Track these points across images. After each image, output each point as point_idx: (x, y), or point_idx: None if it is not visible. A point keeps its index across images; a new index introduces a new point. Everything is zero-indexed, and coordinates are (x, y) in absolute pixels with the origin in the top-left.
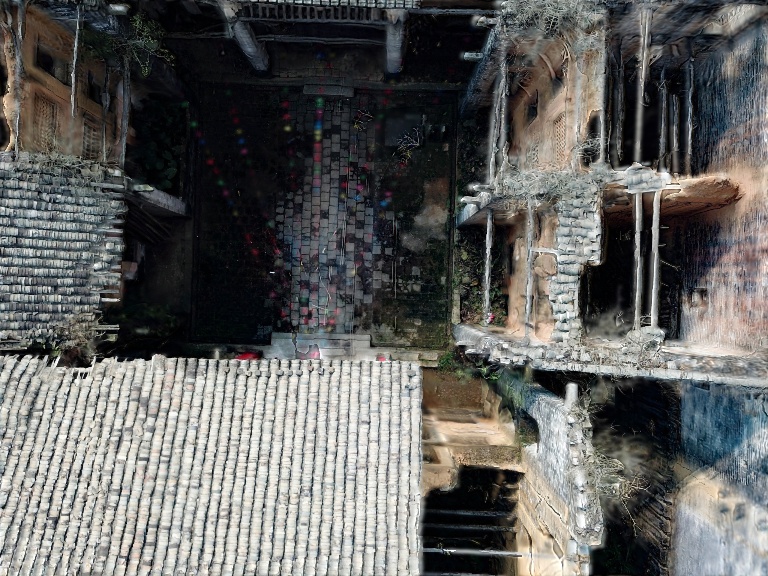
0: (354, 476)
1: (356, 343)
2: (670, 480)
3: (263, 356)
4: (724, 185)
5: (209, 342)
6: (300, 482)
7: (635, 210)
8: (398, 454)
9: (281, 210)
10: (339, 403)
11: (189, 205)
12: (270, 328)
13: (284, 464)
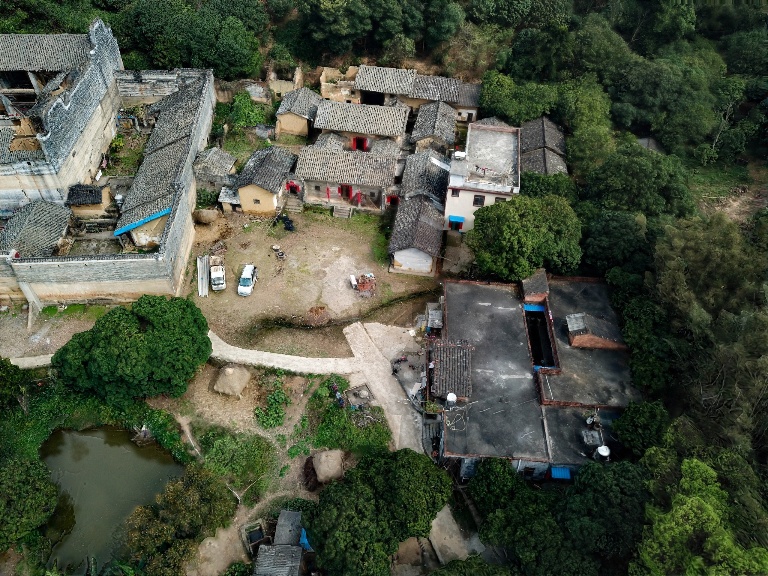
0: None
1: None
2: None
3: None
4: None
5: None
6: (3, 54)
7: None
8: None
9: None
10: None
11: None
12: None
13: (6, 56)
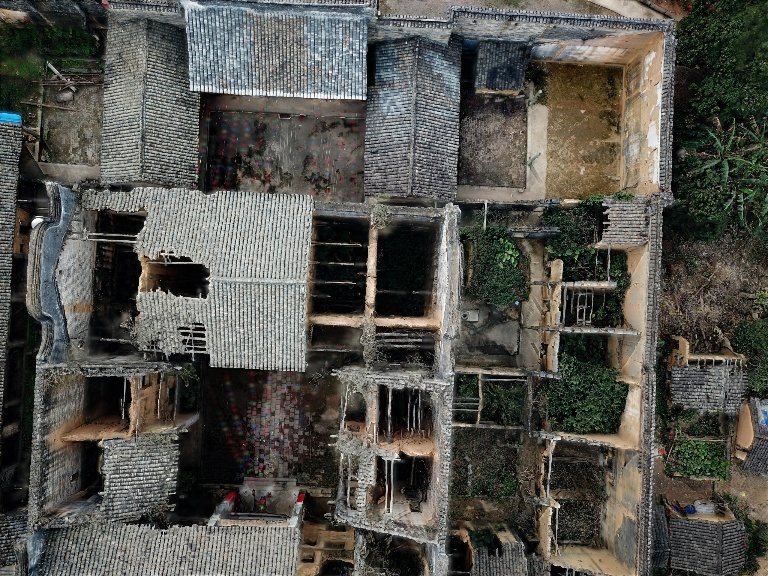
0: (270, 575)
1: (289, 483)
2: (423, 566)
3: (239, 491)
4: (421, 455)
5: (210, 482)
6: None
7: (385, 466)
8: (288, 567)
9: (250, 412)
10: (266, 545)
11: (201, 412)
12: (243, 475)
13: (244, 571)
